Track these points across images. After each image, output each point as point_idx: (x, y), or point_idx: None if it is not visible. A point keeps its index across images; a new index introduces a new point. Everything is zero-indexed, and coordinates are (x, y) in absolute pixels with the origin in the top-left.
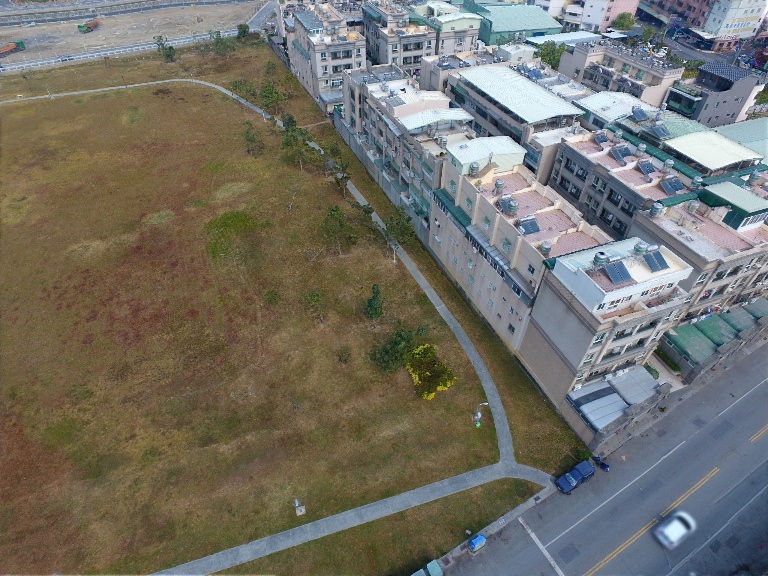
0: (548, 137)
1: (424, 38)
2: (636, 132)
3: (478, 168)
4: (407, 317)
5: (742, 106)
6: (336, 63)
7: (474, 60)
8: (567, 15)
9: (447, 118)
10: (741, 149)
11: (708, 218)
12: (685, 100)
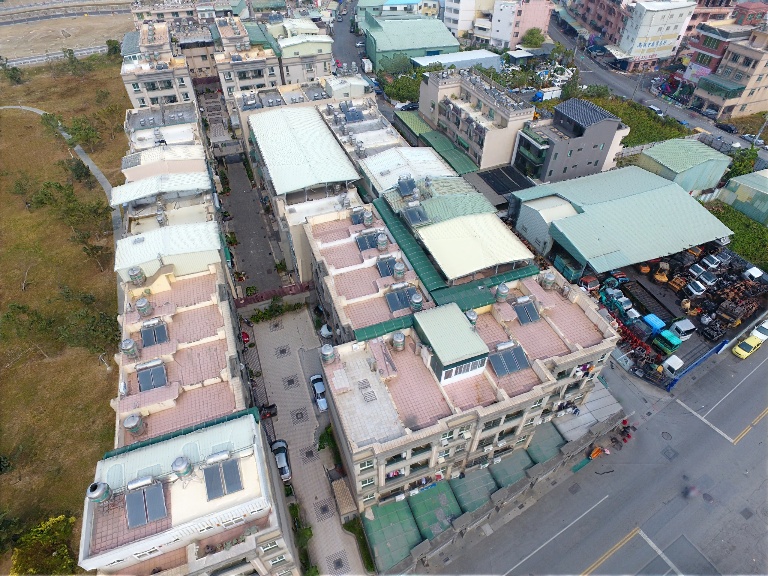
0: (310, 209)
1: (263, 65)
2: (395, 212)
3: (136, 276)
4: (73, 462)
5: (606, 153)
6: (154, 95)
7: (298, 95)
8: (476, 29)
9: (168, 189)
10: (508, 243)
11: (420, 356)
12: (534, 147)
